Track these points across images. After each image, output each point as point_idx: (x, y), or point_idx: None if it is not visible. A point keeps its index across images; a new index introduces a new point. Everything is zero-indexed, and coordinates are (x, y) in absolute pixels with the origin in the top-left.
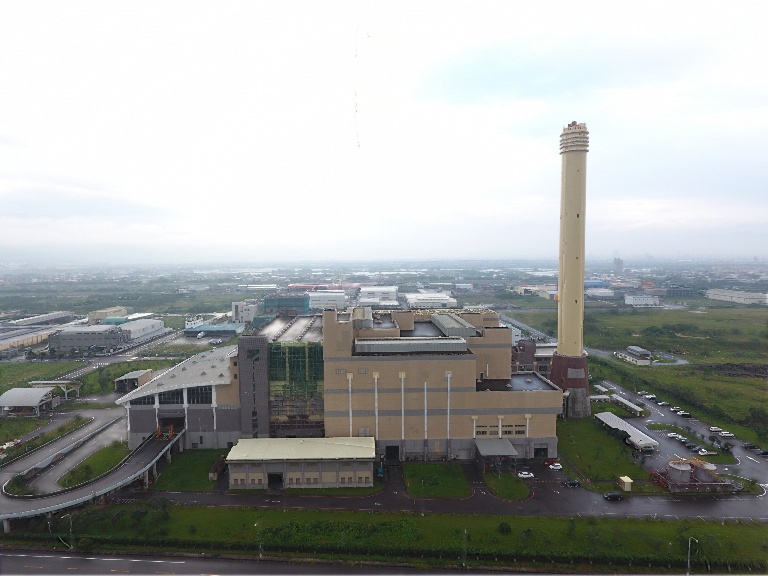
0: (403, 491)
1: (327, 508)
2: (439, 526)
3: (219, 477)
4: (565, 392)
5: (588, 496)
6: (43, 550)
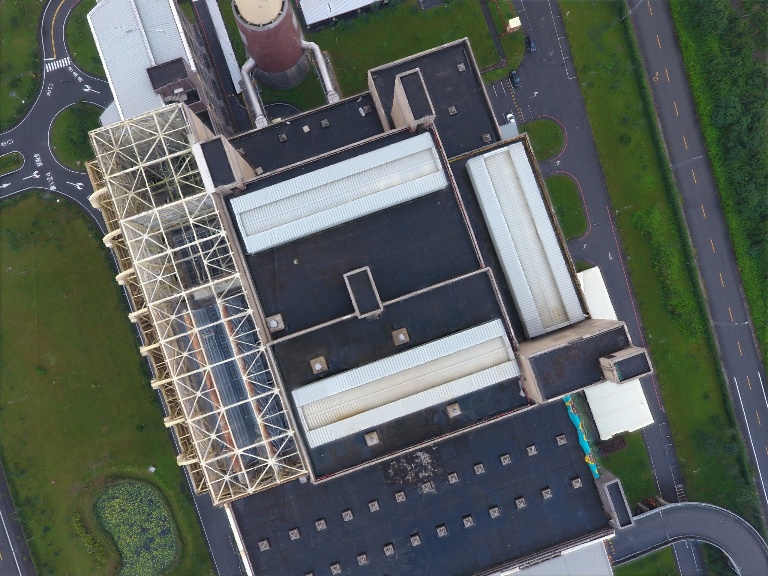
0: (580, 240)
1: (633, 300)
2: (634, 193)
3: (616, 437)
4: (312, 46)
5: (535, 66)
6: (761, 500)
